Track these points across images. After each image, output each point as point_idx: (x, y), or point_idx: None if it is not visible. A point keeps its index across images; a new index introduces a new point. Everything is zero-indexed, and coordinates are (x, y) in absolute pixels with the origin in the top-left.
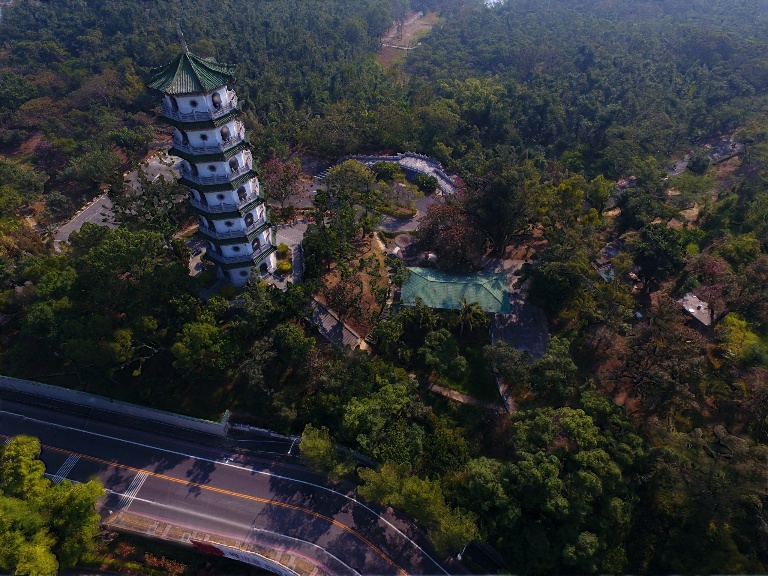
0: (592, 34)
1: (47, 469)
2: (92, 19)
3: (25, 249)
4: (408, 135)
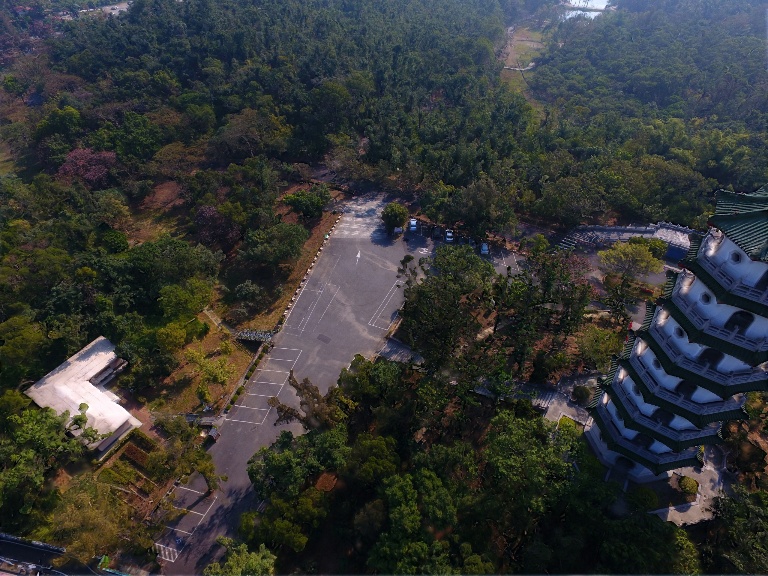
0: (760, 57)
1: None
2: (205, 45)
3: (312, 414)
4: None
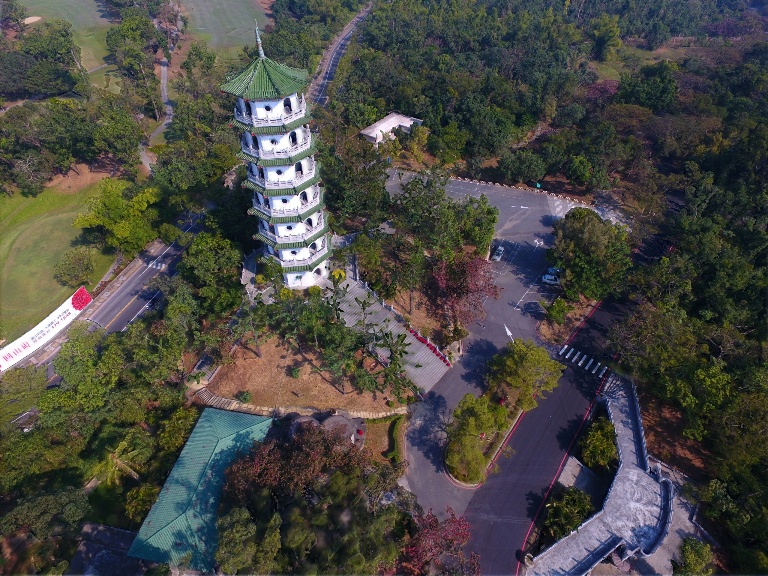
0: None
1: (192, 228)
2: None
3: None
4: (763, 497)
